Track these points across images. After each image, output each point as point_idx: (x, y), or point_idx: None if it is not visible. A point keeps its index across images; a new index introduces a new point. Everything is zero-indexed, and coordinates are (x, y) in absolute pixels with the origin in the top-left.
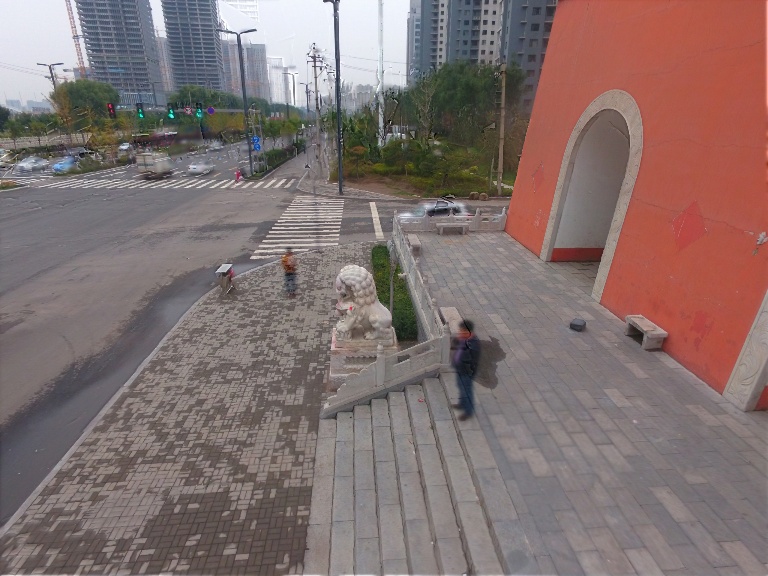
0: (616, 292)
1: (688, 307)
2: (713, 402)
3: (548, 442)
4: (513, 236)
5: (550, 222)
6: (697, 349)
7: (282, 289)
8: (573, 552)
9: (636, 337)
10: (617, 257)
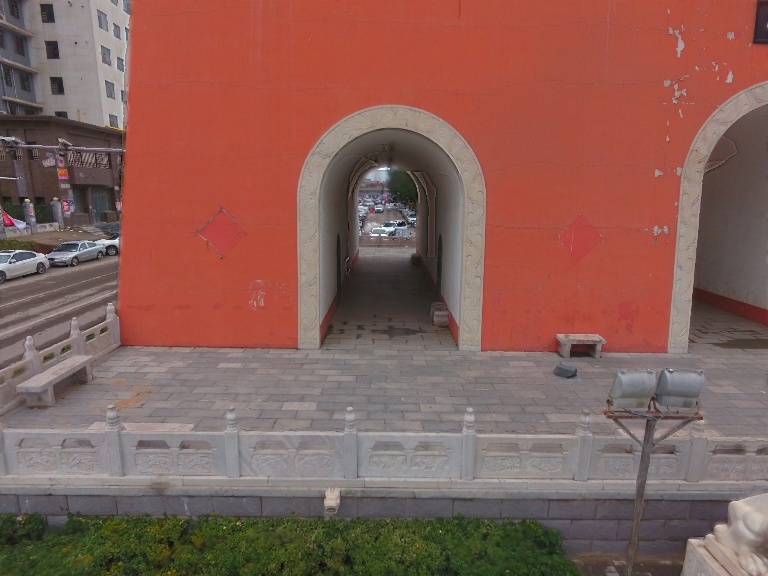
0: (504, 329)
1: (609, 304)
2: (684, 358)
3: None
4: (171, 344)
5: (306, 291)
6: (632, 332)
7: None
8: None
9: (572, 355)
10: (489, 293)
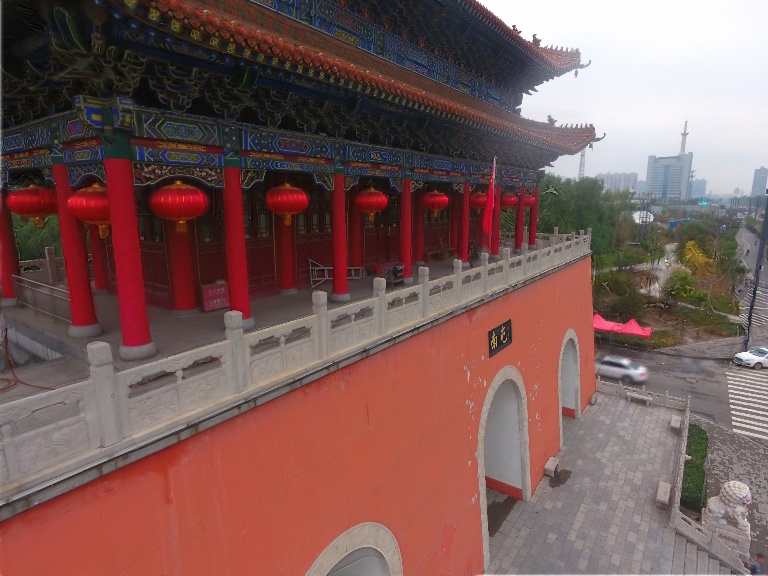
0: None
1: None
2: (496, 573)
3: None
4: None
5: None
6: None
7: None
8: (640, 575)
9: None
10: None
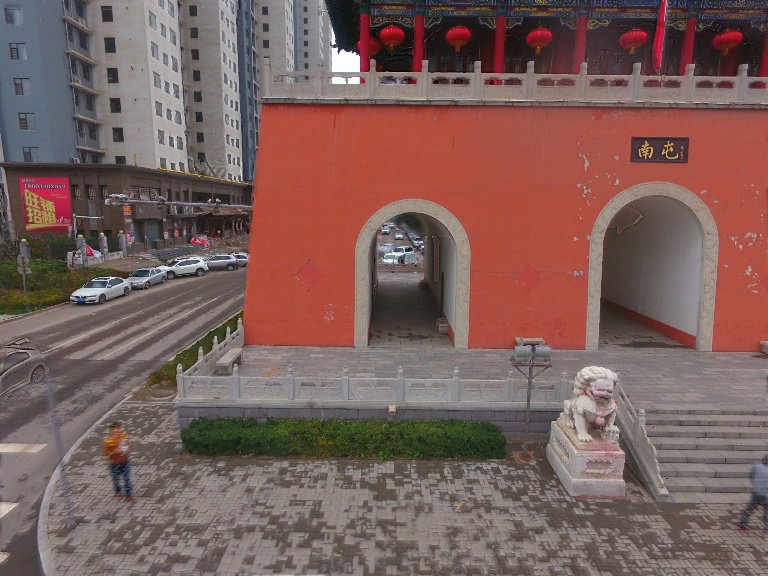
0: (483, 334)
1: (548, 319)
2: None
3: None
4: (276, 344)
5: (360, 311)
6: (563, 337)
7: (305, 566)
8: None
9: None
10: (473, 312)
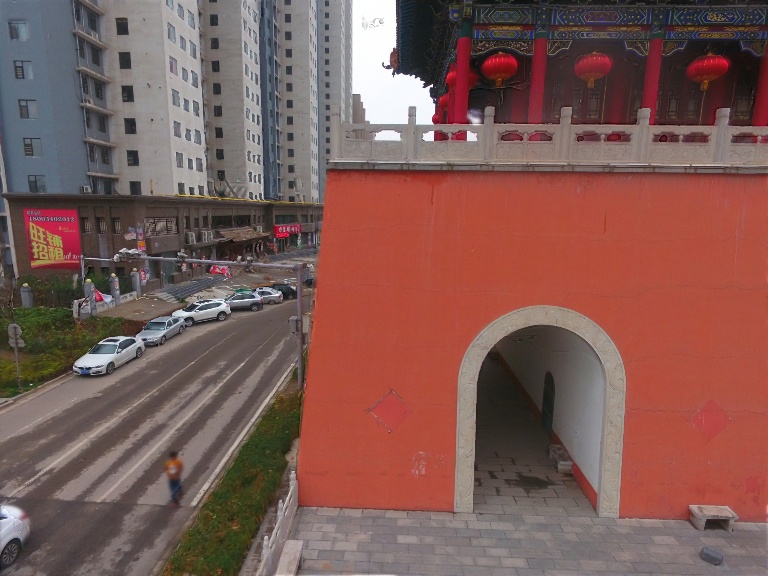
0: (640, 498)
1: (737, 479)
2: None
3: None
4: (342, 506)
5: (463, 462)
6: (758, 504)
7: None
8: None
9: (705, 526)
10: (627, 467)
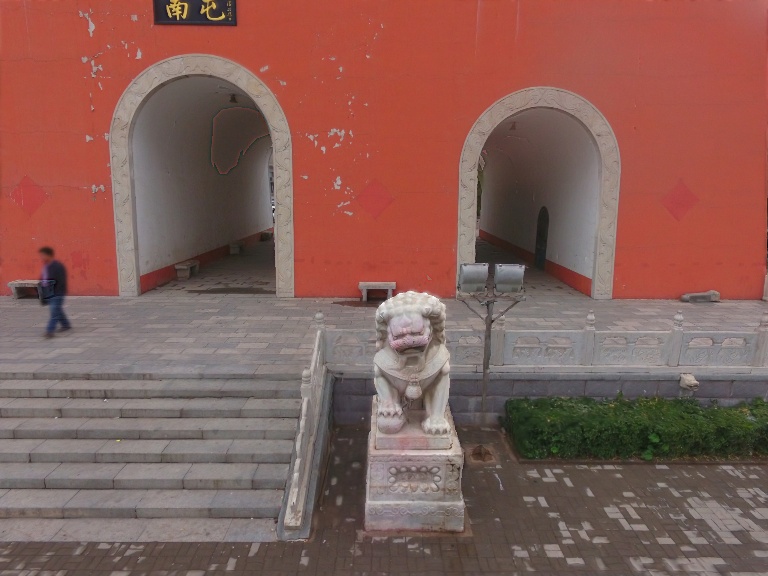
0: None
1: (62, 253)
2: (120, 299)
3: (60, 344)
4: None
5: None
6: (86, 278)
7: None
8: (146, 354)
9: (26, 297)
10: None
